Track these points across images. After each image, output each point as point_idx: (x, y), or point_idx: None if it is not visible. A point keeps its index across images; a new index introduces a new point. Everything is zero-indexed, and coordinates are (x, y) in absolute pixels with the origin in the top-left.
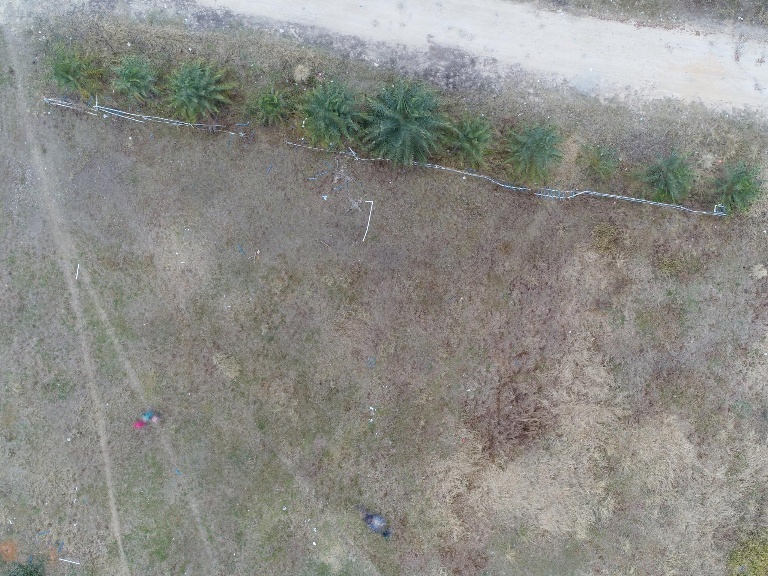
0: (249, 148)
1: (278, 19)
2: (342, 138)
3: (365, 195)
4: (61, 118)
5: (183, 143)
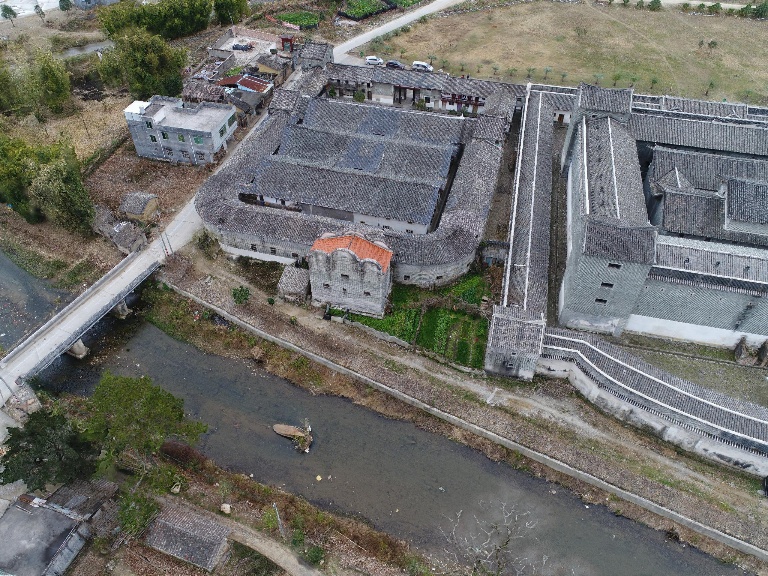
0: (726, 18)
1: (724, 7)
2: (746, 18)
3: (756, 23)
4: (682, 14)
5: (711, 17)
